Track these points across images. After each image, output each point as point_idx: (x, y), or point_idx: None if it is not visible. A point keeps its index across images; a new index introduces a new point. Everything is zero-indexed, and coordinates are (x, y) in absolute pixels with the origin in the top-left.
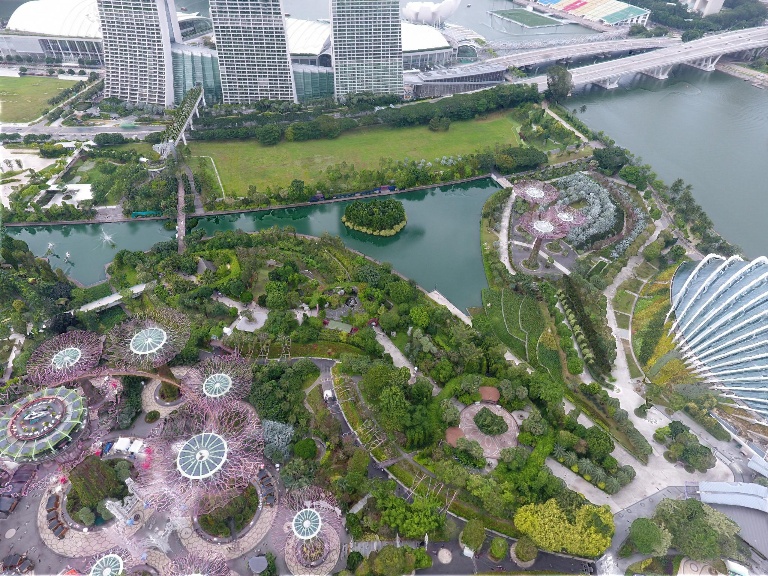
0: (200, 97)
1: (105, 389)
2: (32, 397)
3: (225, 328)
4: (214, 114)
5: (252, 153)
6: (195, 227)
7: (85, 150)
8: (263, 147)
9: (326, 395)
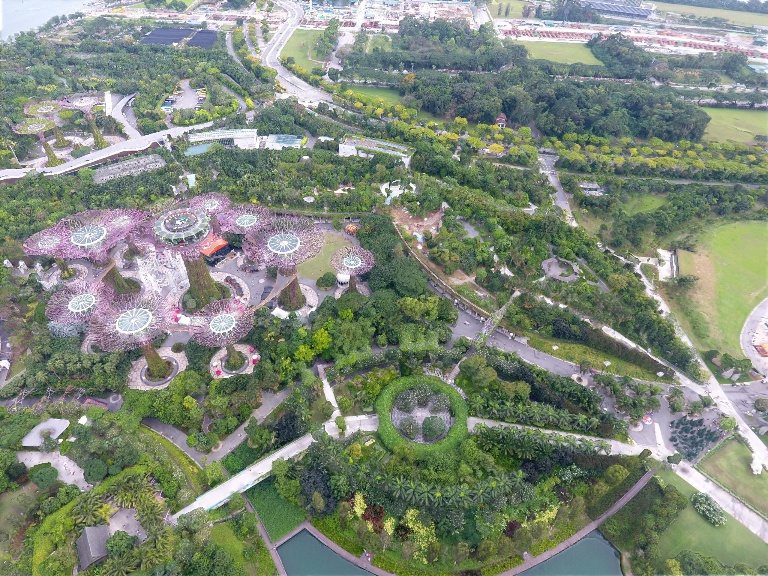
0: None
1: (144, 244)
2: (192, 233)
3: (84, 421)
4: None
5: None
6: None
7: None
8: None
9: (2, 352)
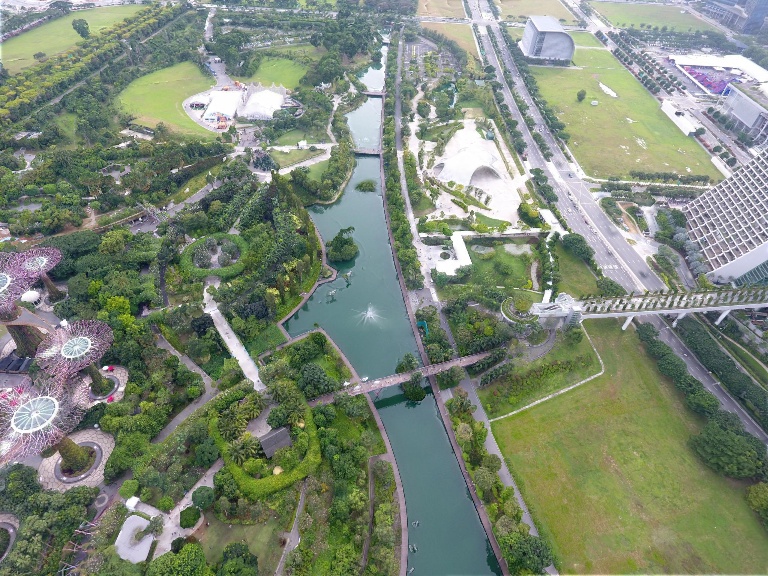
0: (762, 305)
1: None
2: None
3: (135, 499)
4: (747, 339)
5: (654, 433)
6: (434, 399)
7: (548, 235)
8: (689, 449)
9: None
